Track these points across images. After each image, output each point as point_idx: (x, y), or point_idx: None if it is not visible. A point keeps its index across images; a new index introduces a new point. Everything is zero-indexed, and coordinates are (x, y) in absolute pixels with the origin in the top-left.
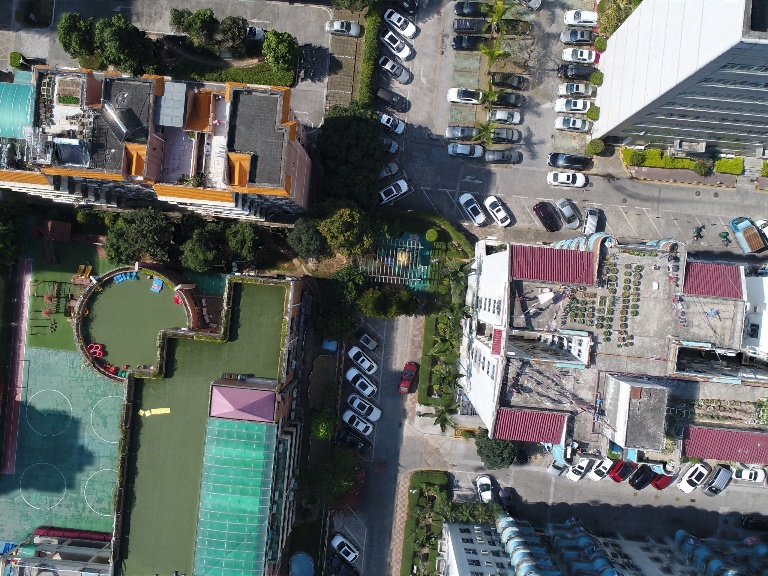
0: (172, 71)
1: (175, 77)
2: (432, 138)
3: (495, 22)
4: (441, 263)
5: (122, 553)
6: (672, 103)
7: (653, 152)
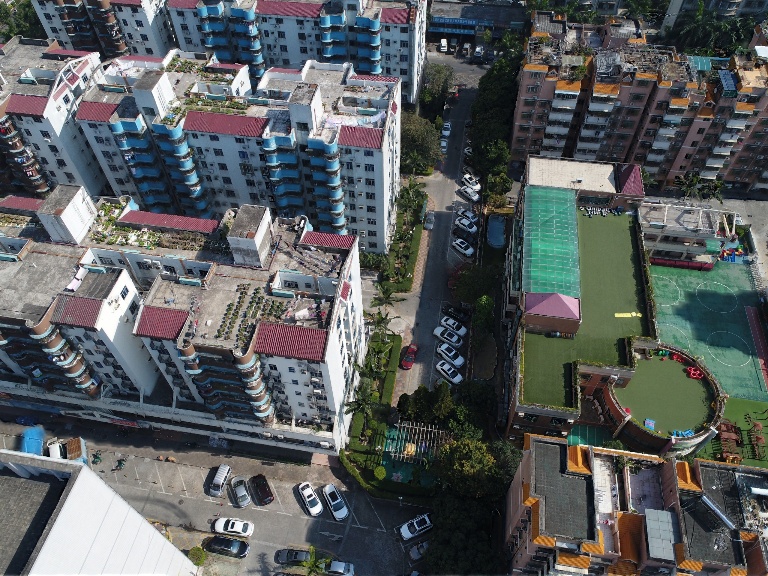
0: None
1: None
2: None
3: None
4: (373, 449)
5: (634, 229)
6: None
7: None
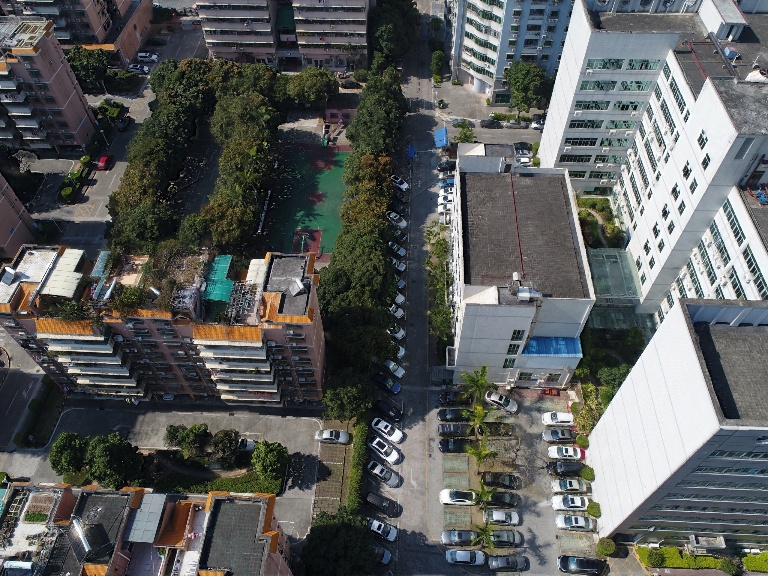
0: (157, 484)
1: (159, 490)
2: (428, 545)
3: (477, 425)
4: None
5: None
6: (673, 494)
7: (670, 550)
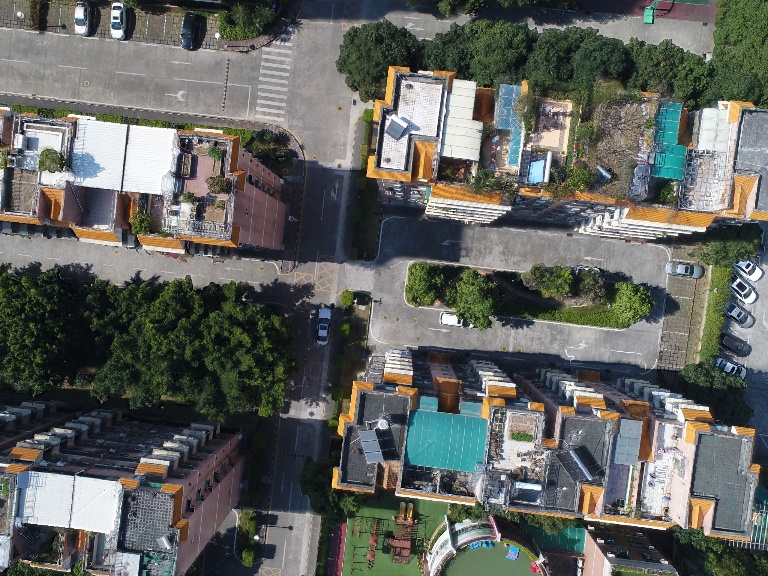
0: (504, 310)
1: (505, 314)
2: None
3: None
4: None
5: None
6: None
7: None
